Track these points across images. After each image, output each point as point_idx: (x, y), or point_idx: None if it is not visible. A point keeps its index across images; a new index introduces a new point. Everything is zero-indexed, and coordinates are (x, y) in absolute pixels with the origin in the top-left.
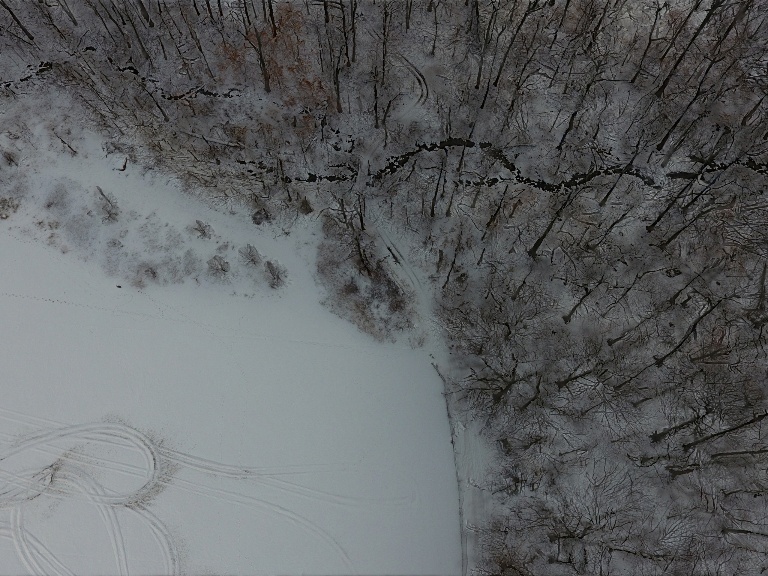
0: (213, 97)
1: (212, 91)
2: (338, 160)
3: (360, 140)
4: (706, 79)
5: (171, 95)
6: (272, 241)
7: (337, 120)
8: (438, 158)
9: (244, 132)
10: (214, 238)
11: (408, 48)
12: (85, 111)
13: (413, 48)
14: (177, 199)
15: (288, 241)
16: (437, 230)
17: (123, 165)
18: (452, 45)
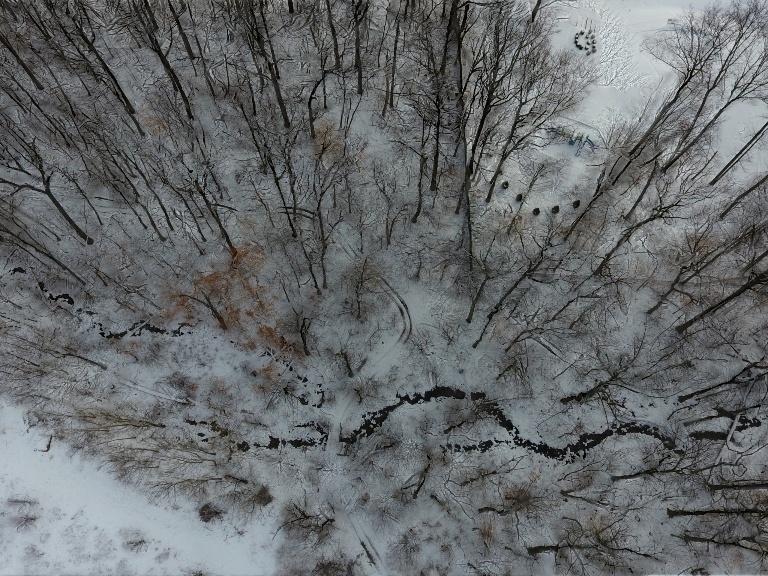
0: (160, 335)
1: (159, 327)
2: (305, 419)
3: (331, 392)
4: (736, 318)
5: (111, 332)
6: (222, 544)
7: (304, 368)
8: (422, 416)
9: (194, 388)
10: (152, 544)
11: (389, 269)
12: (4, 370)
13: (394, 268)
14: (110, 490)
15: (242, 543)
16: (420, 520)
17: (47, 445)
18: (440, 269)
